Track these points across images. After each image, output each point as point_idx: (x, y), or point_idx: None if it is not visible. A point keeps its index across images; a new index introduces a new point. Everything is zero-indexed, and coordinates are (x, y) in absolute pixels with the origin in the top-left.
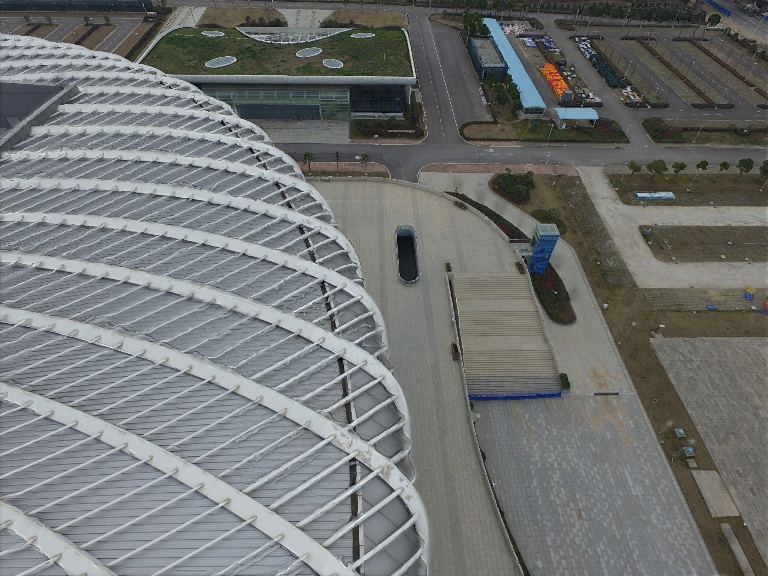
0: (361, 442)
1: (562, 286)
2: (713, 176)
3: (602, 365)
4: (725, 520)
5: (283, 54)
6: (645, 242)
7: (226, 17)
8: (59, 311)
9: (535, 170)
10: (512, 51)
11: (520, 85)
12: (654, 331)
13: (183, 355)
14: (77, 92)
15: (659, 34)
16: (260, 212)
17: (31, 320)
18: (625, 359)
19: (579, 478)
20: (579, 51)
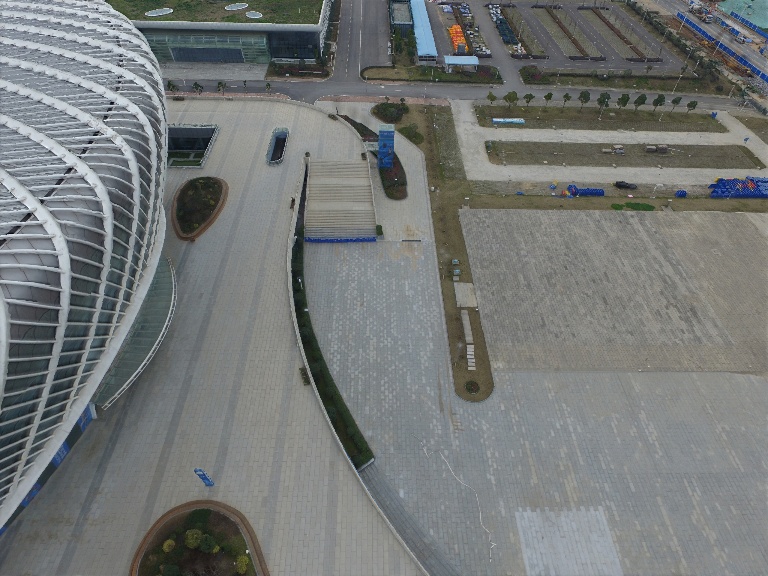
0: (103, 124)
1: (403, 175)
2: (563, 108)
3: (415, 224)
4: (465, 308)
5: (214, 7)
6: (486, 151)
7: None
8: None
9: (414, 101)
10: (425, 13)
11: (420, 38)
12: (463, 204)
13: (15, 85)
14: None
15: (568, 4)
16: (96, 46)
17: None
18: (435, 221)
19: (370, 285)
20: (489, 16)
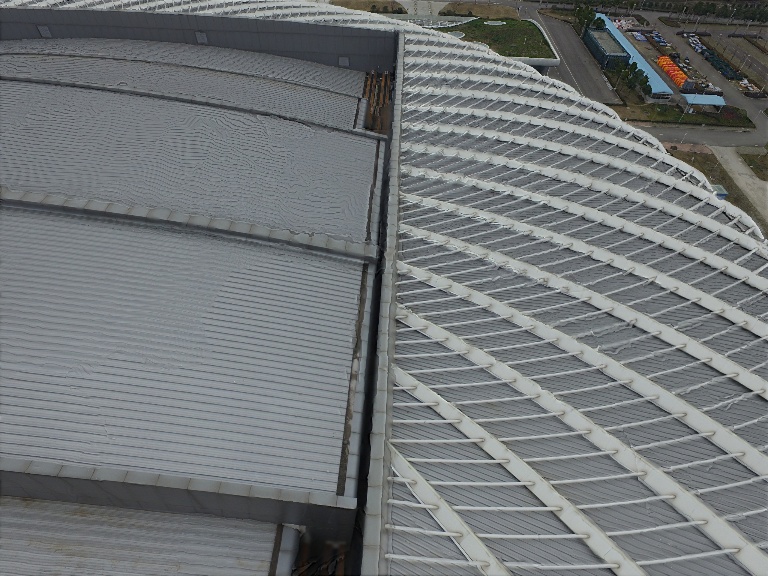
0: None
1: None
2: None
3: None
4: None
5: None
6: None
7: (351, 6)
8: (537, 163)
9: None
10: (628, 43)
11: (645, 73)
12: None
13: (637, 193)
14: (405, 38)
15: (764, 33)
16: (602, 123)
17: (525, 166)
18: None
19: None
20: (689, 46)
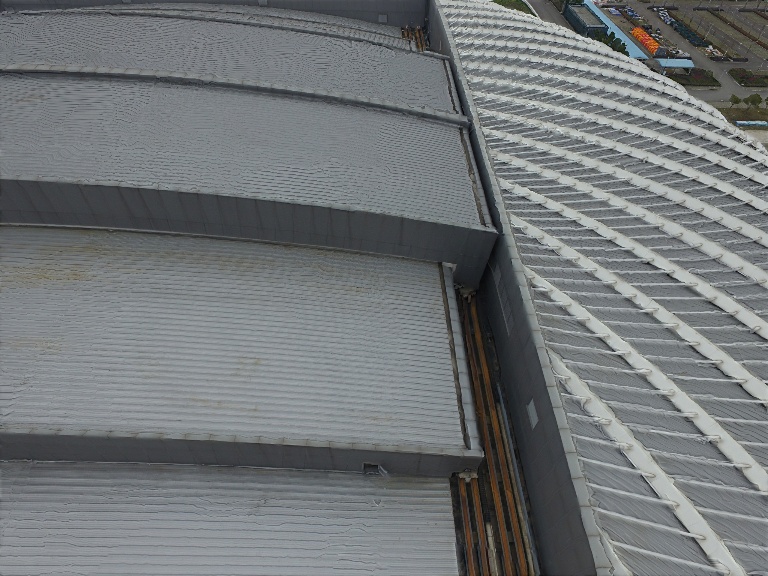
0: None
1: None
2: None
3: None
4: None
5: None
6: None
7: None
8: None
9: None
10: (605, 16)
11: (622, 41)
12: None
13: None
14: None
15: (725, 6)
16: (604, 53)
17: None
18: None
19: None
20: (659, 19)
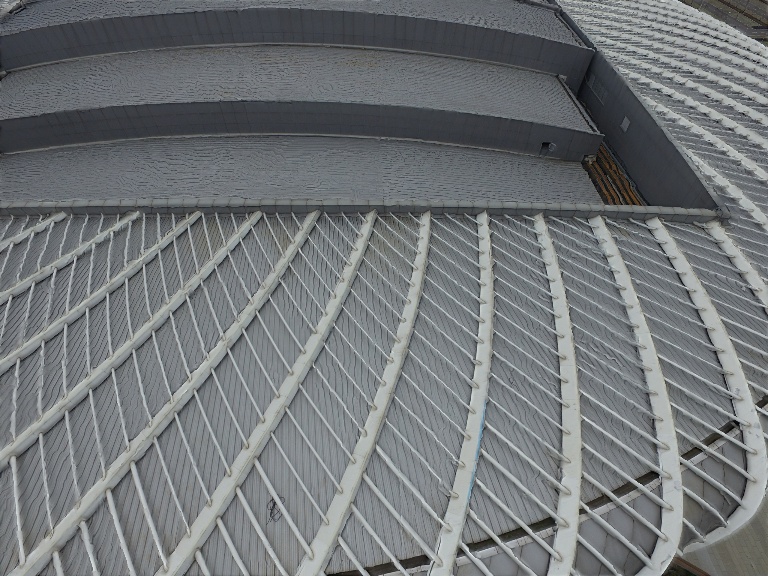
0: None
1: None
2: None
3: None
4: None
5: None
6: None
7: None
8: None
9: None
10: None
11: None
12: None
13: (661, 3)
14: None
15: None
16: None
17: None
18: None
19: None
20: None
